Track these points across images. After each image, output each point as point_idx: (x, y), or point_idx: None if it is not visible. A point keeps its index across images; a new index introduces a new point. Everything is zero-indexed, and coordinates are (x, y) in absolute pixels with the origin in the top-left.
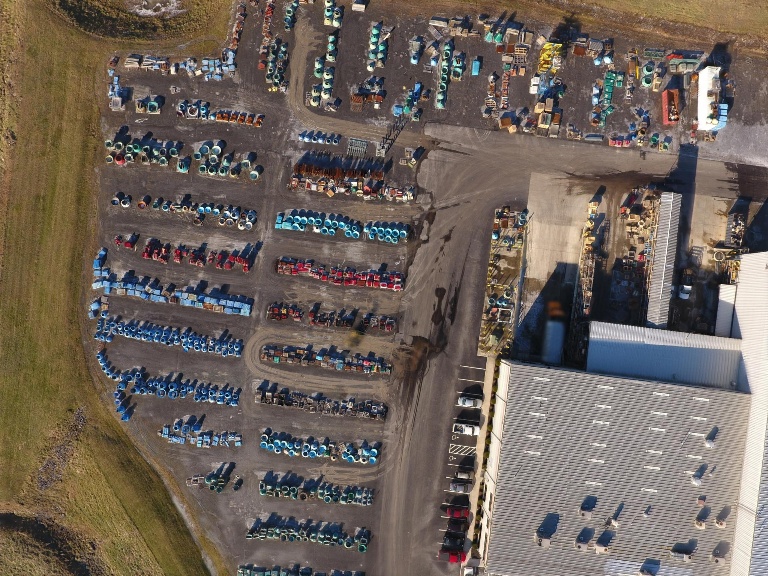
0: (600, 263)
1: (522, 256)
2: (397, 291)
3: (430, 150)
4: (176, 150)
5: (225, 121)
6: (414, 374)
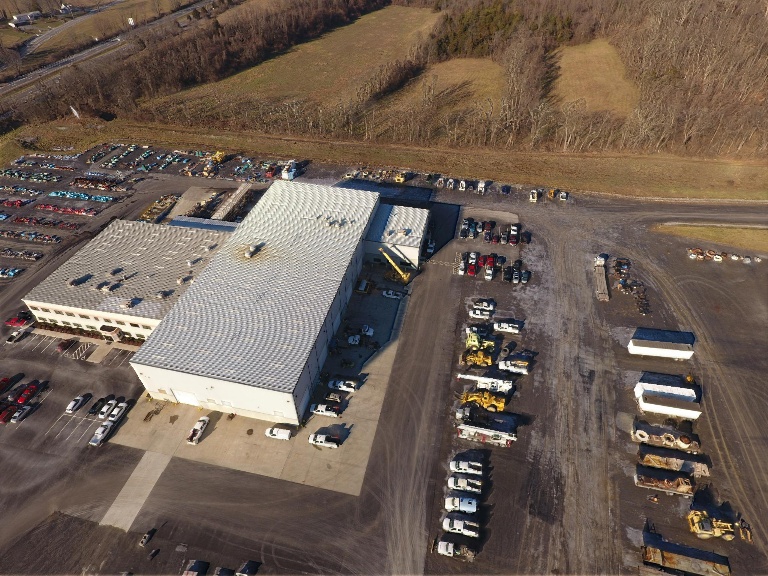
0: (209, 212)
1: (169, 210)
2: (91, 216)
3: (146, 179)
4: (26, 174)
5: (58, 169)
6: (72, 244)
